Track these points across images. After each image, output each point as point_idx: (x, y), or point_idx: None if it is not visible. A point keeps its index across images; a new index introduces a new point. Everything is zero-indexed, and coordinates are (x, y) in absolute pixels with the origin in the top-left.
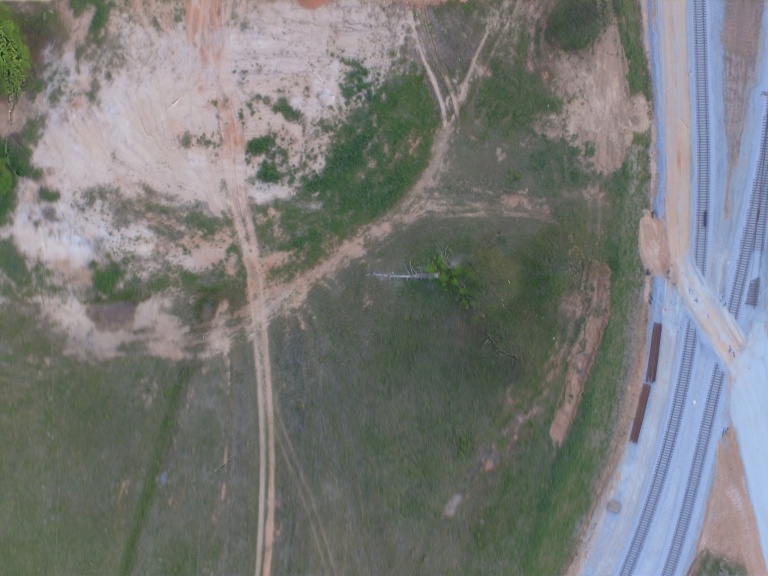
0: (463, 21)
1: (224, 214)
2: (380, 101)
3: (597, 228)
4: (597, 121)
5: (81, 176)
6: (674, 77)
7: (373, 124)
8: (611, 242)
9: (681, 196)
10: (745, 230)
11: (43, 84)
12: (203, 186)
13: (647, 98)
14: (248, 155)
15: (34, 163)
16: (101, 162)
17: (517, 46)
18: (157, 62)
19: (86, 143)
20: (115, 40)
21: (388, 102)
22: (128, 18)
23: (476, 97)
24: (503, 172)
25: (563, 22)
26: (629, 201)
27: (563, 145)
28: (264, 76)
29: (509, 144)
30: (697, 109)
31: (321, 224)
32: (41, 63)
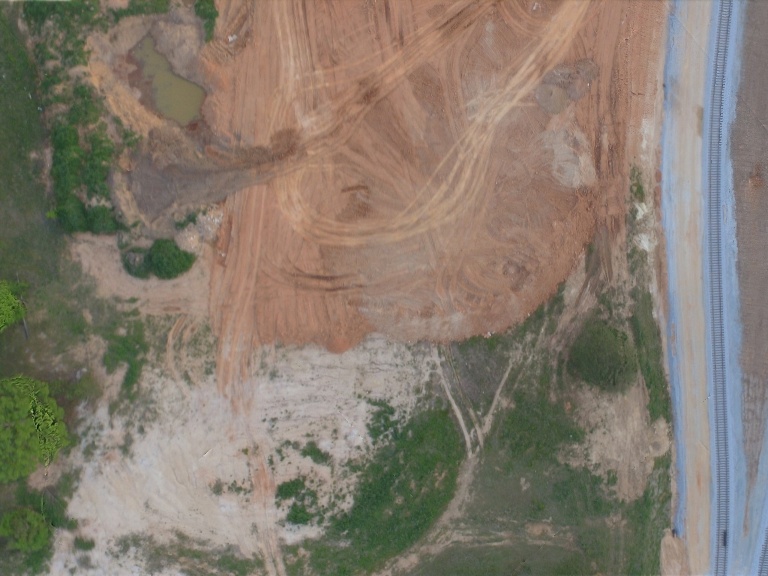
0: (487, 356)
1: (255, 556)
2: (406, 439)
3: (620, 555)
4: (619, 450)
5: (115, 525)
6: (693, 400)
7: (400, 461)
8: (633, 569)
9: (701, 515)
10: (764, 548)
11: (77, 439)
12: (234, 530)
13: (667, 421)
14: (278, 499)
15: (69, 514)
16: (134, 511)
17: (540, 378)
18: (189, 415)
19: (120, 494)
20: (147, 395)
21: (414, 439)
22: (160, 373)
23: (500, 428)
24: (527, 502)
25: (585, 354)
26: (651, 526)
27: (586, 474)
28: (293, 422)
29: (533, 474)
30: (716, 432)
31: (350, 561)
32: (75, 418)
